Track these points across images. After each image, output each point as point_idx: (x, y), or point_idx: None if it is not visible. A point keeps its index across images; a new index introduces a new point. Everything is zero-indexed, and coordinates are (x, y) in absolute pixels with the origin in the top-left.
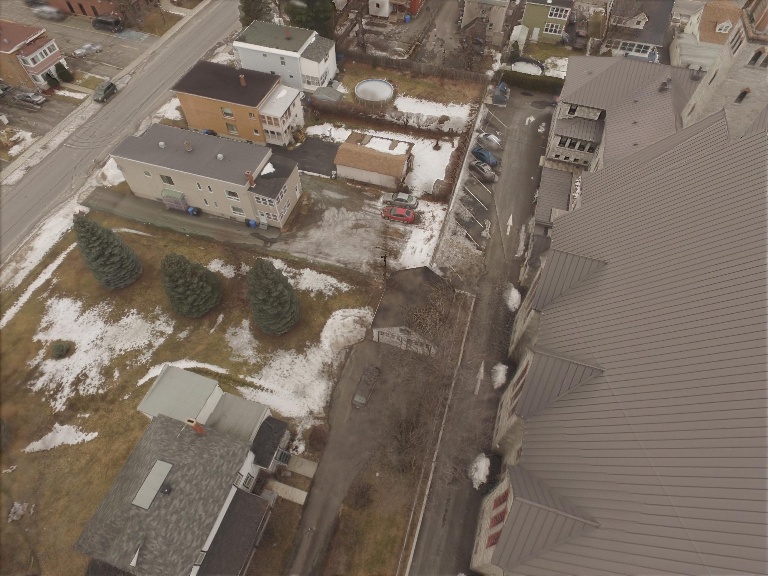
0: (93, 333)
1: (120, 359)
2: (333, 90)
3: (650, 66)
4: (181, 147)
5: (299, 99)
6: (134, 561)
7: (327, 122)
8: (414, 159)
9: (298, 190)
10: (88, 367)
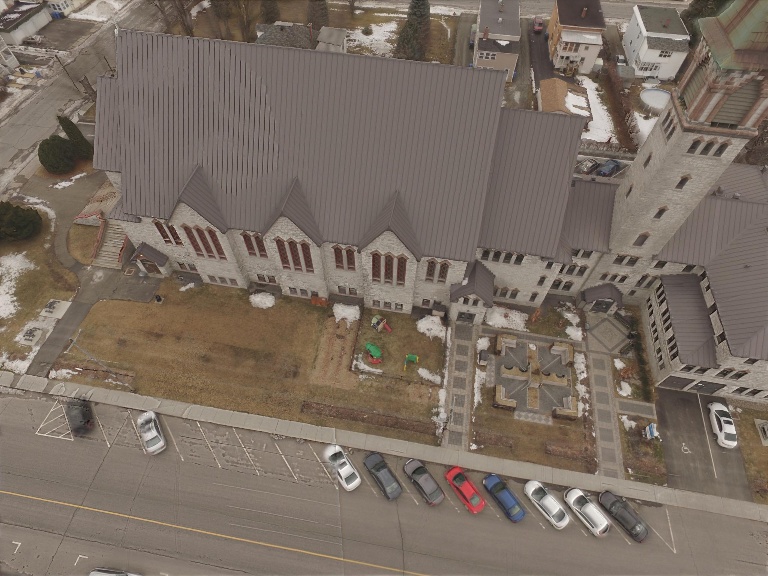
0: (379, 37)
1: (366, 48)
2: (632, 72)
3: (761, 191)
4: (503, 8)
5: (598, 51)
6: (259, 36)
7: (599, 84)
8: (583, 132)
9: (508, 75)
10: (359, 41)
